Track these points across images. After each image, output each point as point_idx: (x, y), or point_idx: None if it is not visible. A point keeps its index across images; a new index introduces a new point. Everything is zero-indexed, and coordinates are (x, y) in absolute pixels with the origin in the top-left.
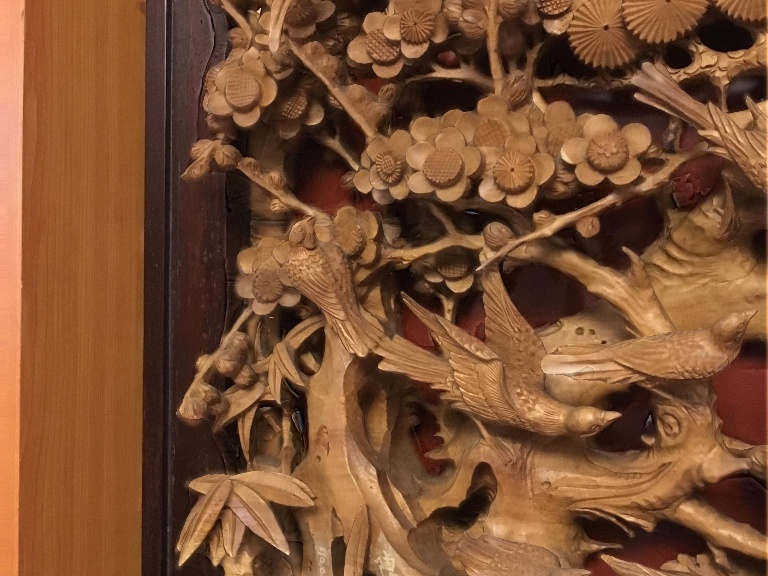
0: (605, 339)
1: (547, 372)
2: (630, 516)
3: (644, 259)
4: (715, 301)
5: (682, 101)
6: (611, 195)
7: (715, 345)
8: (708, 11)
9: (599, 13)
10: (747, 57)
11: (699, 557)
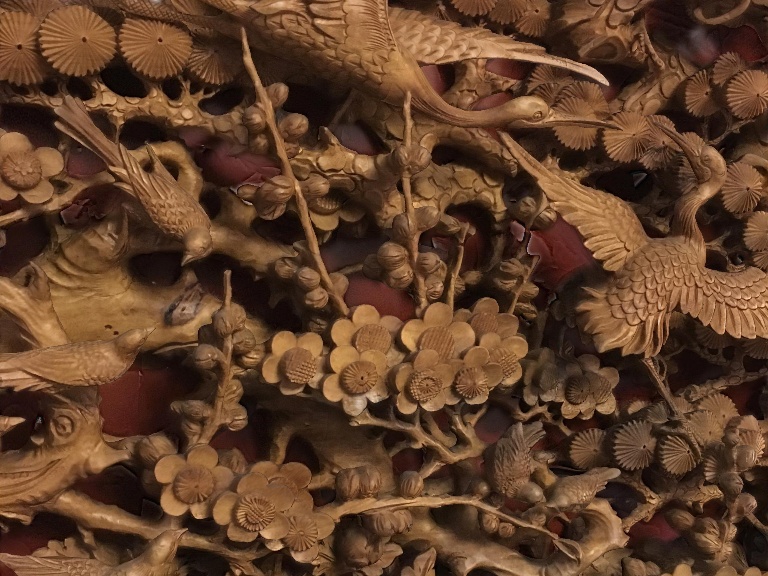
0: None
1: None
2: (12, 513)
3: (31, 269)
4: (97, 312)
5: (98, 138)
6: (20, 211)
7: (118, 356)
8: (115, 58)
9: (13, 31)
10: (142, 105)
11: (67, 541)
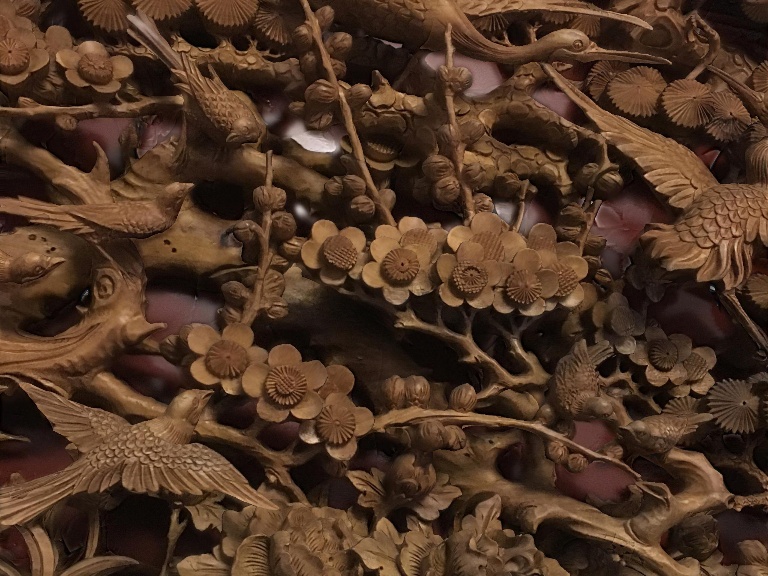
0: (55, 246)
1: (5, 209)
2: (49, 382)
3: None
4: None
5: (163, 44)
6: (91, 105)
7: (158, 208)
8: (190, 10)
9: None
10: (212, 53)
11: None
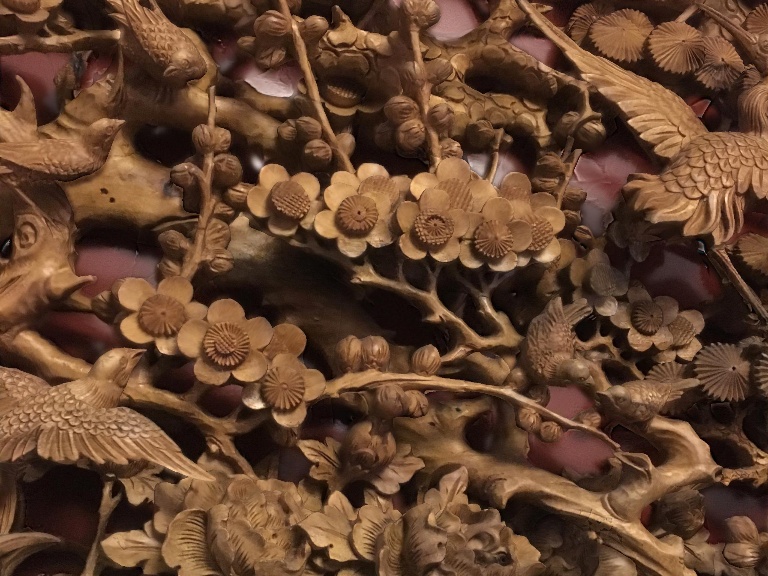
0: None
1: None
2: None
3: None
4: None
5: None
6: (16, 36)
7: (84, 147)
8: None
9: None
10: None
11: None
